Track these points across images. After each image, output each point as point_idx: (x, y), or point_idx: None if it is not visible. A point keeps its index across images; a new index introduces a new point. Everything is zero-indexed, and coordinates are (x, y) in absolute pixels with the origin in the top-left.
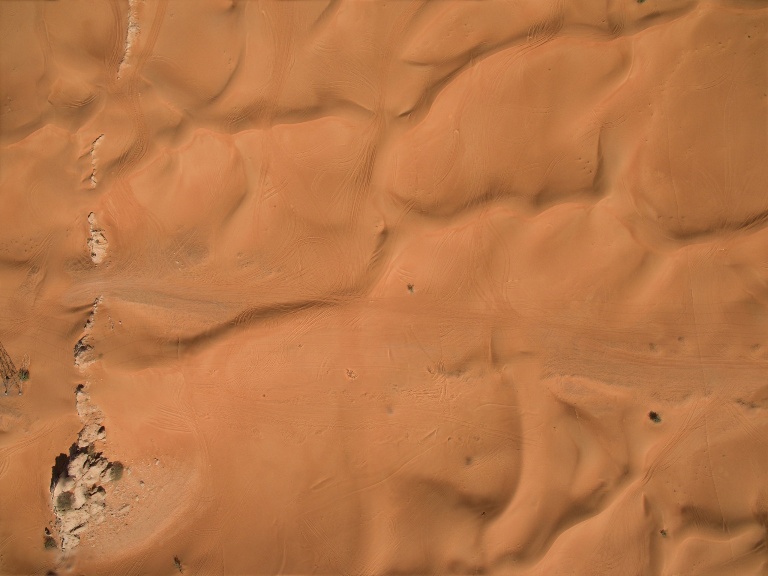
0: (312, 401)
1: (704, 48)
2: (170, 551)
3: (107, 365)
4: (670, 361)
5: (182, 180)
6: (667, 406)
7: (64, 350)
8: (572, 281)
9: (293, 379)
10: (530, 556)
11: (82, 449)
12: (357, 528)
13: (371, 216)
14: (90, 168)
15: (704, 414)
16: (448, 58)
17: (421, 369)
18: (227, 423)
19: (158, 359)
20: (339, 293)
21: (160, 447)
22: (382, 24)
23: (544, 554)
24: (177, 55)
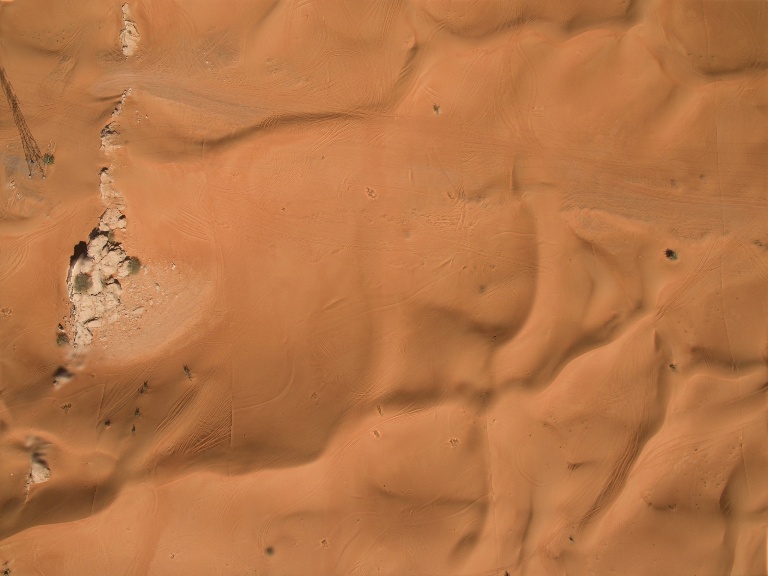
0: (331, 219)
1: None
2: (180, 360)
3: (132, 153)
4: (690, 198)
5: None
6: (684, 243)
7: (90, 135)
8: (598, 113)
9: (314, 194)
10: (538, 382)
11: (102, 232)
12: (368, 346)
13: (402, 31)
14: None
15: (720, 255)
16: None
17: (441, 194)
18: (245, 235)
19: (182, 156)
20: (365, 107)
21: (177, 251)
22: None
23: (552, 380)
24: None
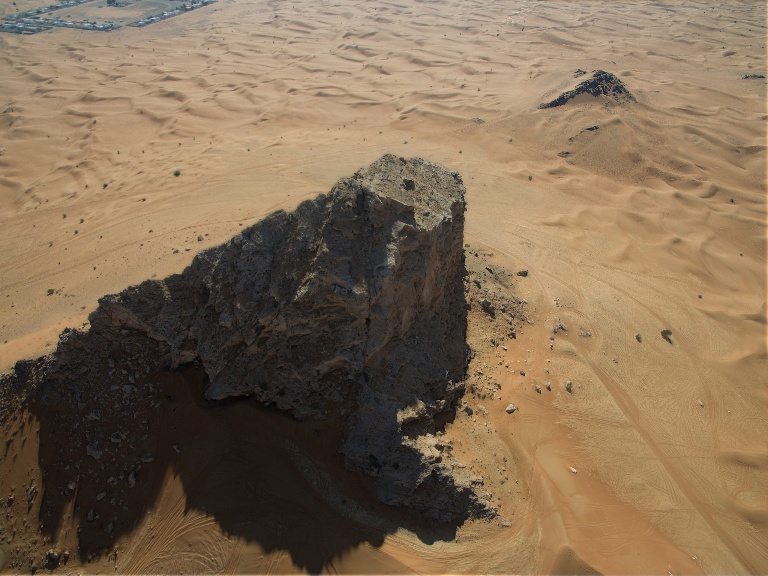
0: None
1: None
2: None
3: None
4: None
5: None
6: None
7: None
8: None
9: None
10: None
11: None
12: (764, 3)
13: (762, 8)
14: None
15: None
16: None
17: None
18: None
19: None
20: None
21: None
22: None
23: None
24: None
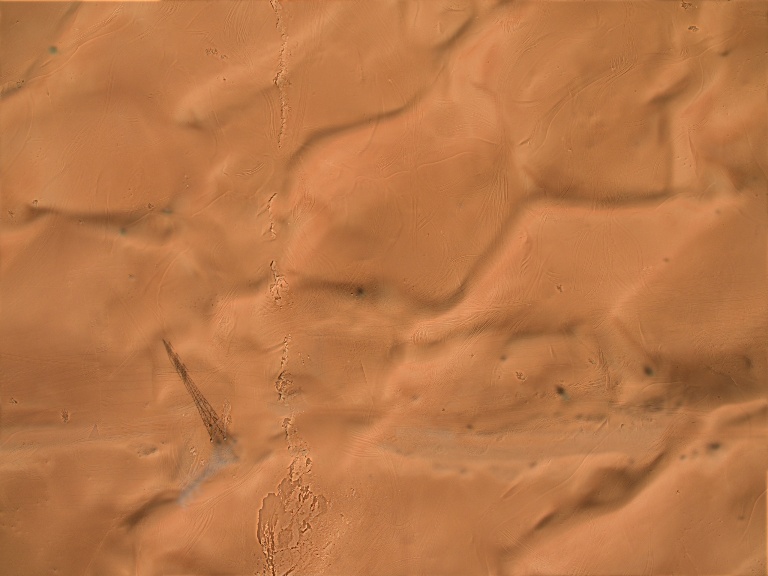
0: (488, 408)
1: (755, 58)
2: None
3: (306, 397)
4: None
5: (348, 222)
6: None
7: (265, 389)
8: (699, 260)
9: (469, 389)
10: (733, 528)
11: (295, 482)
12: (558, 529)
13: (514, 230)
14: (268, 223)
15: None
16: (549, 94)
17: (583, 362)
18: (412, 443)
19: (348, 386)
20: (498, 301)
21: (355, 476)
22: (489, 76)
23: (747, 523)
24: (324, 123)
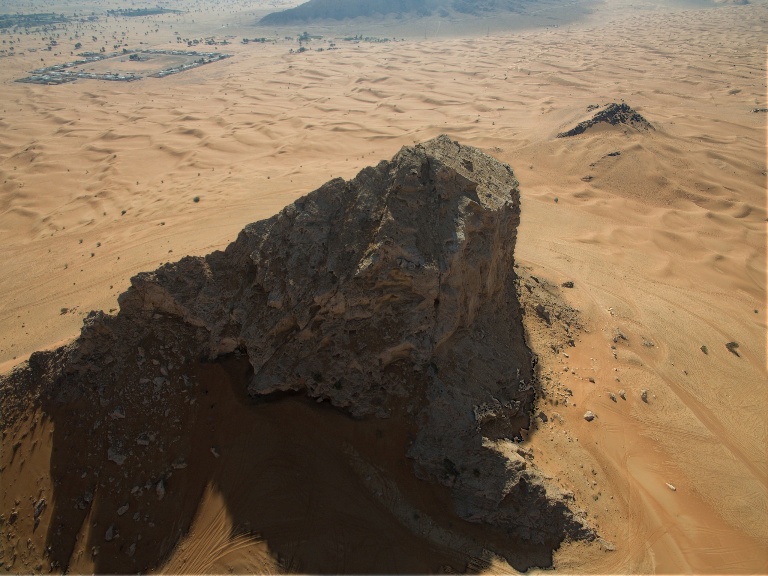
0: None
1: None
2: None
3: None
4: None
5: None
6: None
7: None
8: None
9: None
10: None
11: None
12: None
13: None
14: None
15: None
16: None
17: None
18: None
19: None
20: None
21: None
22: None
23: None
24: None
